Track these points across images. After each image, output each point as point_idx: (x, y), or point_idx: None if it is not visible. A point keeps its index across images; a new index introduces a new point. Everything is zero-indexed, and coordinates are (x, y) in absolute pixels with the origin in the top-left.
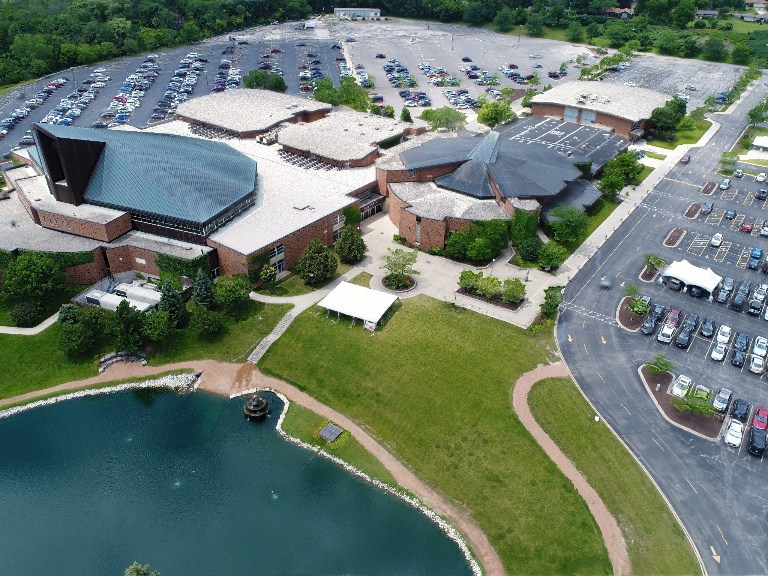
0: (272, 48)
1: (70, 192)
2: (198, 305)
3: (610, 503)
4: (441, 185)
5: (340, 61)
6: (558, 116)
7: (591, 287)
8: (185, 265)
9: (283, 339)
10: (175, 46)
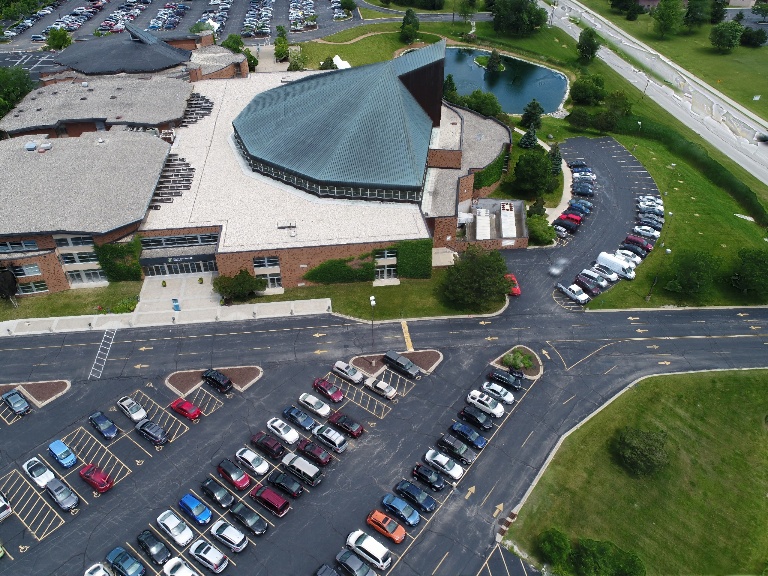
0: None
1: None
2: None
3: (363, 34)
4: None
5: None
6: None
7: None
8: None
9: None
10: None
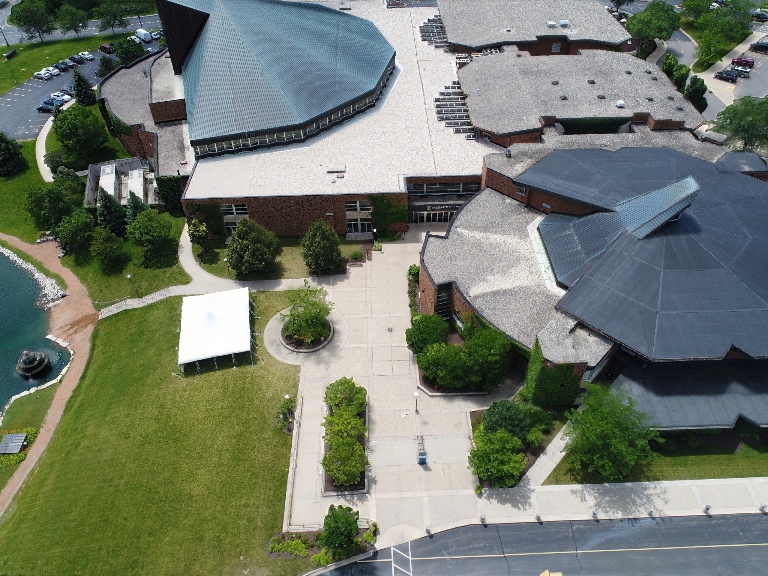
0: None
1: None
2: None
3: None
4: (539, 229)
5: None
6: None
7: (496, 568)
8: None
9: (137, 312)
10: None
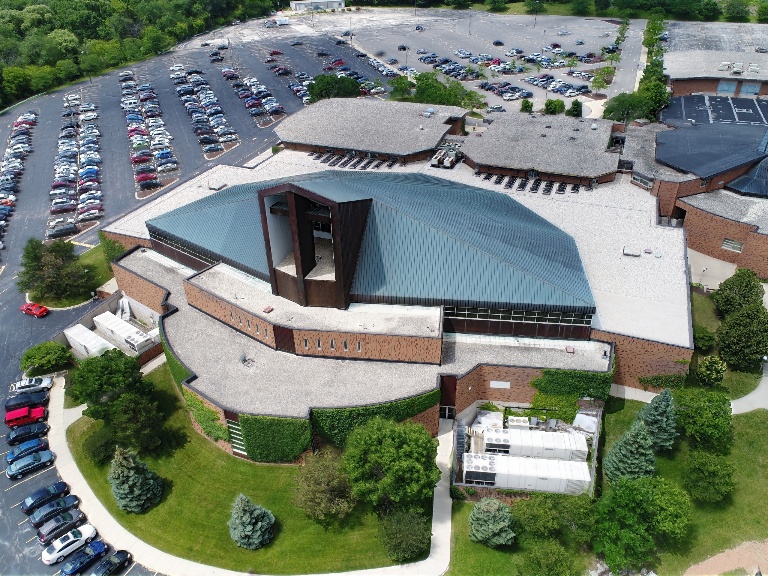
0: (266, 50)
1: (338, 290)
2: (655, 446)
3: None
4: (749, 192)
5: (362, 58)
6: (709, 92)
7: None
8: (599, 382)
9: None
10: (140, 59)
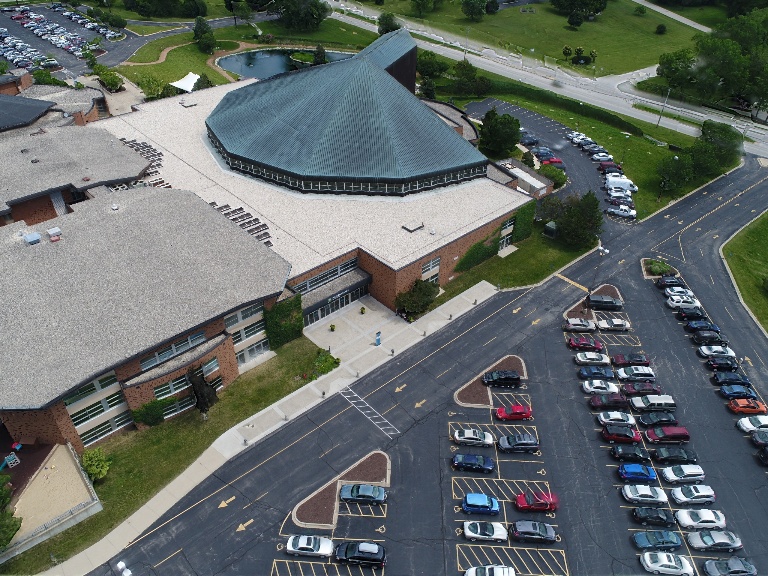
0: None
1: None
2: None
3: None
4: None
5: None
6: None
7: None
8: None
9: None
10: None
